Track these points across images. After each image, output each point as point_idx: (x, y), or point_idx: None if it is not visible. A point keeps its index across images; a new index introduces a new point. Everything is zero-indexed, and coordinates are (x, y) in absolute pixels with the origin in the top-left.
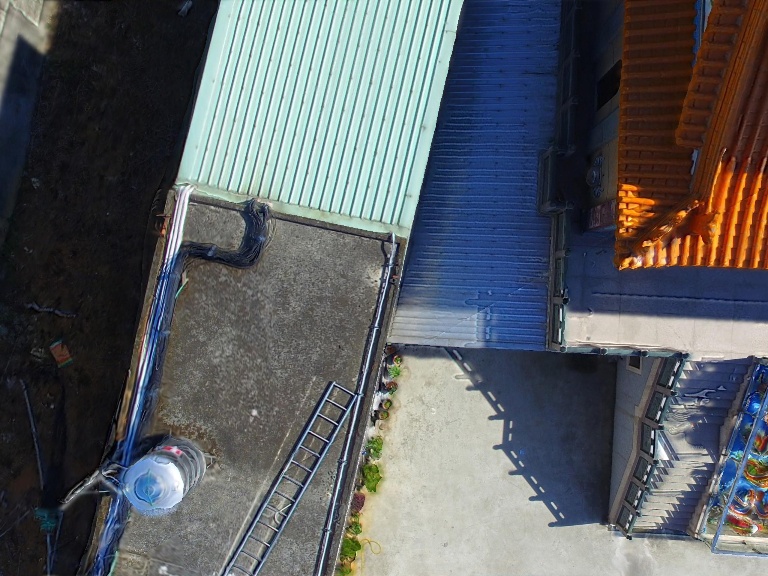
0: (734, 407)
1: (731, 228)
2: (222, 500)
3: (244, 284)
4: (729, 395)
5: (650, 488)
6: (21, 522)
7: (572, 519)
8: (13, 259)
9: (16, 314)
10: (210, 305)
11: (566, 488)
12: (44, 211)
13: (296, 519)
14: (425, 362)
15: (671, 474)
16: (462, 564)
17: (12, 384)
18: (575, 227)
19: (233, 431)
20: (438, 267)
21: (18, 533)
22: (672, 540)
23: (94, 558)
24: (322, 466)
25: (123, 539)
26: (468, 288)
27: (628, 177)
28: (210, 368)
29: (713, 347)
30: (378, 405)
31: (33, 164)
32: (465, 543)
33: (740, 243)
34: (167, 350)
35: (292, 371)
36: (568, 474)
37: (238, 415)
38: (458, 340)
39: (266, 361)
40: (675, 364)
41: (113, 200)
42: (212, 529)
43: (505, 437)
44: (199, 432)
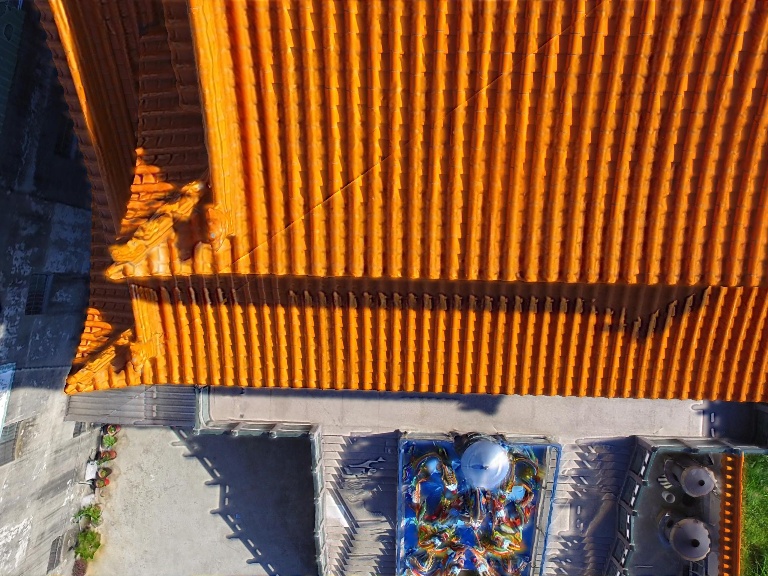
0: None
1: (185, 349)
2: None
3: None
4: (391, 465)
5: (317, 558)
6: None
7: None
8: None
9: None
10: None
11: (282, 550)
12: None
13: None
14: (143, 430)
15: (358, 540)
16: None
17: None
18: None
19: None
20: None
21: None
22: None
23: None
24: None
25: None
26: None
27: (95, 301)
28: None
29: (361, 422)
30: (95, 474)
31: None
32: None
33: (197, 363)
34: None
35: None
36: (283, 536)
37: None
38: (128, 418)
39: None
40: None
41: None
42: None
43: (221, 501)
44: None
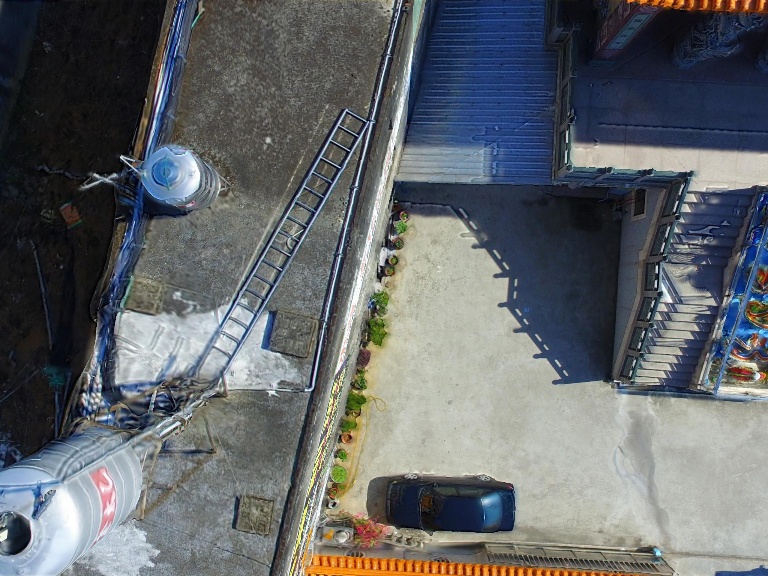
0: (738, 244)
1: None
2: (236, 227)
3: (259, 14)
4: (733, 231)
5: (654, 323)
6: (30, 381)
7: (576, 376)
8: (24, 122)
9: (27, 176)
10: (225, 35)
11: (570, 346)
12: (55, 75)
13: (308, 245)
14: (431, 220)
15: (675, 320)
16: (466, 421)
17: (22, 245)
18: (582, 56)
19: (247, 159)
20: (446, 104)
21: (27, 392)
22: (675, 398)
23: (110, 278)
24: (334, 193)
25: (138, 266)
26: (475, 124)
27: None
28: (225, 97)
29: (717, 177)
30: (384, 261)
31: (45, 28)
32: (469, 400)
33: None
34: (183, 79)
35: (305, 99)
36: (572, 332)
37: (252, 143)
38: (465, 175)
39: (280, 90)
40: (680, 187)
41: (123, 64)
42: (226, 255)
43: (510, 295)
44: (214, 160)
